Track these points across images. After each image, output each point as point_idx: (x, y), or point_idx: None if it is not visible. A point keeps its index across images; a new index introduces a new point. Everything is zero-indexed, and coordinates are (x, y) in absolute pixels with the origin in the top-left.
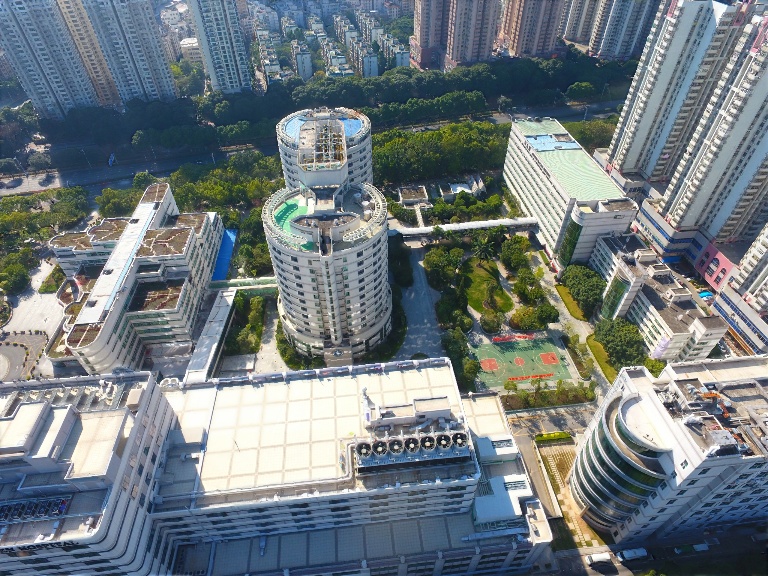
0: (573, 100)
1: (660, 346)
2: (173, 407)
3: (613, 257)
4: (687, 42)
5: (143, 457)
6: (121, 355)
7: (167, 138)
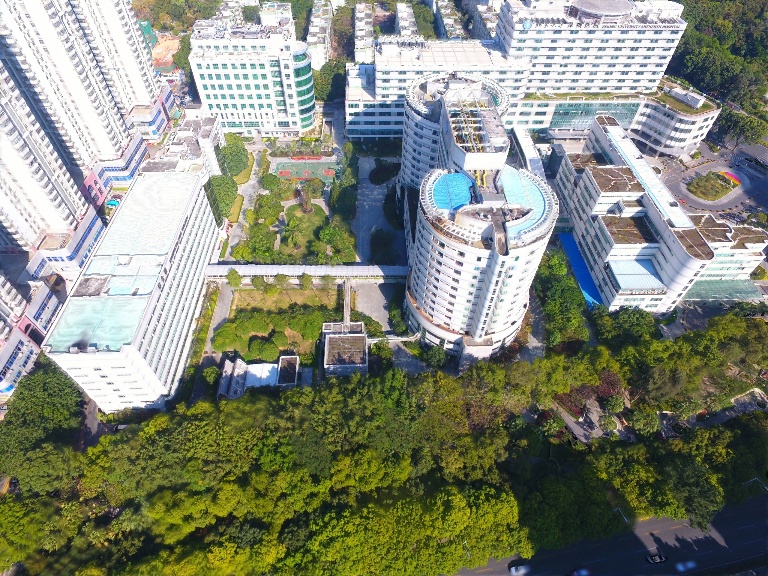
0: None
1: None
2: (511, 62)
3: None
4: None
5: None
6: None
7: None
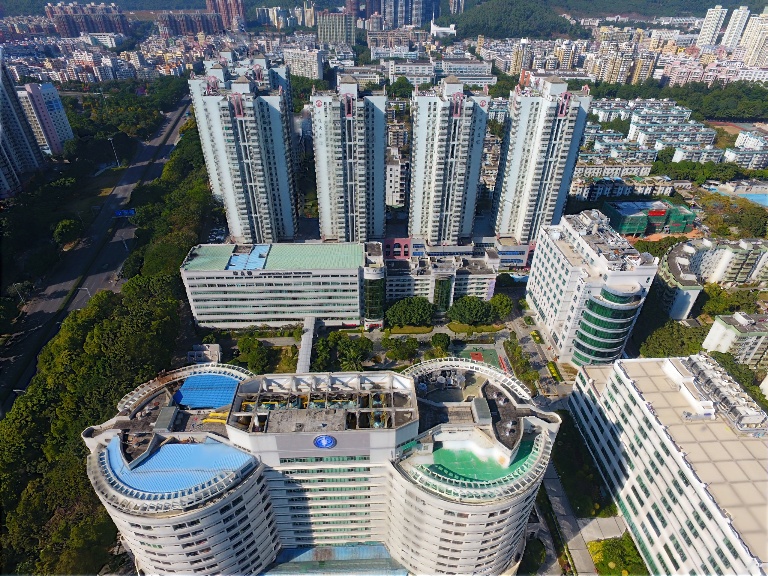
0: (69, 243)
1: (491, 288)
2: None
3: (414, 277)
4: (261, 131)
5: None
6: None
7: None
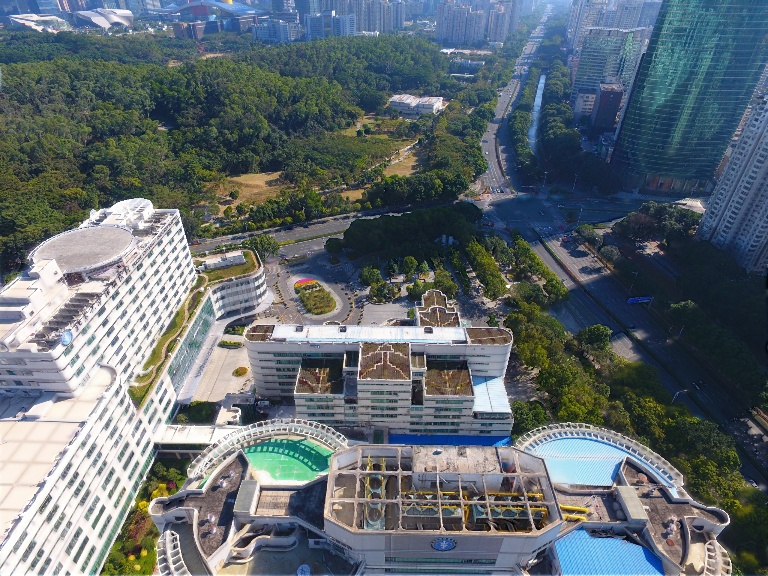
0: None
1: None
2: (87, 393)
3: None
4: None
5: (4, 371)
6: (269, 370)
7: (701, 333)
